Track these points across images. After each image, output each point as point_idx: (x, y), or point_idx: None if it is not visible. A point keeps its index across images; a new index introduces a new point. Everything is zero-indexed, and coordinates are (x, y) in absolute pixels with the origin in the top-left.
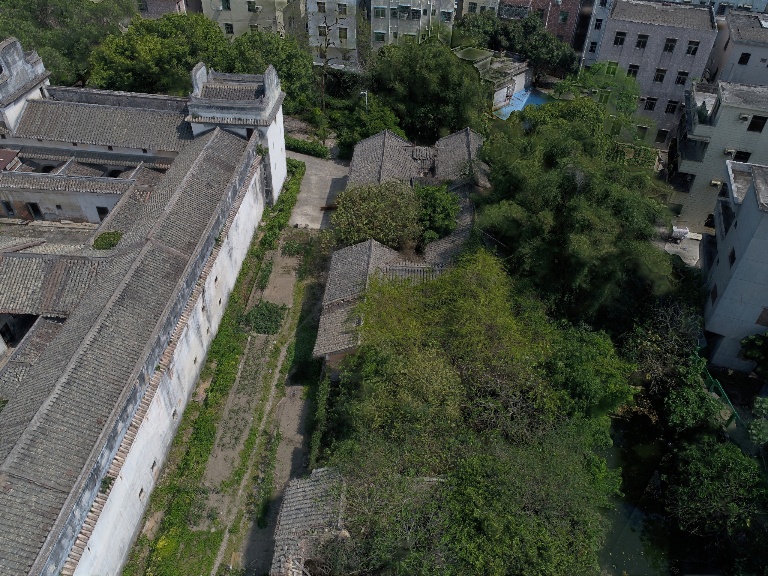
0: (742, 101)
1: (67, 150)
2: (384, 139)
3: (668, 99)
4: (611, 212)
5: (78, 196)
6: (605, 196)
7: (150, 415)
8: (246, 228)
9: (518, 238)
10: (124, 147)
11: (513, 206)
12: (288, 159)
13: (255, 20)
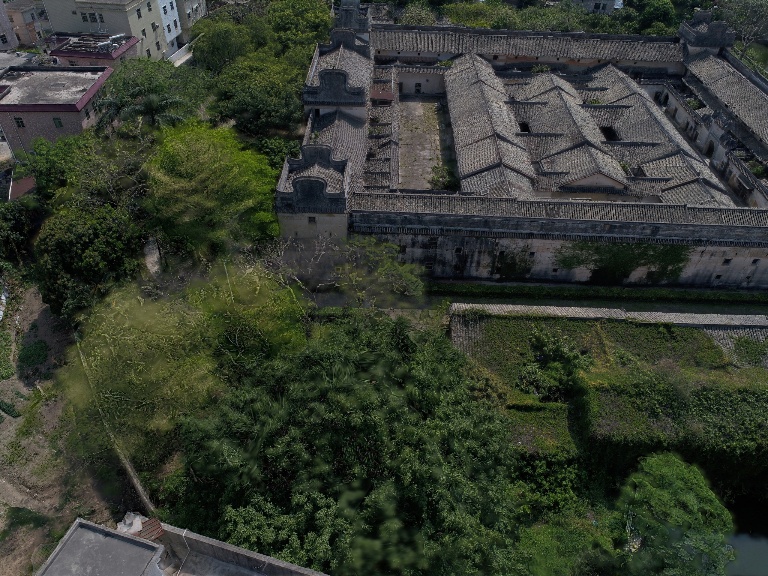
0: None
1: None
2: None
3: None
4: None
5: None
6: None
7: None
8: None
9: None
10: None
11: None
12: None
13: (157, 37)
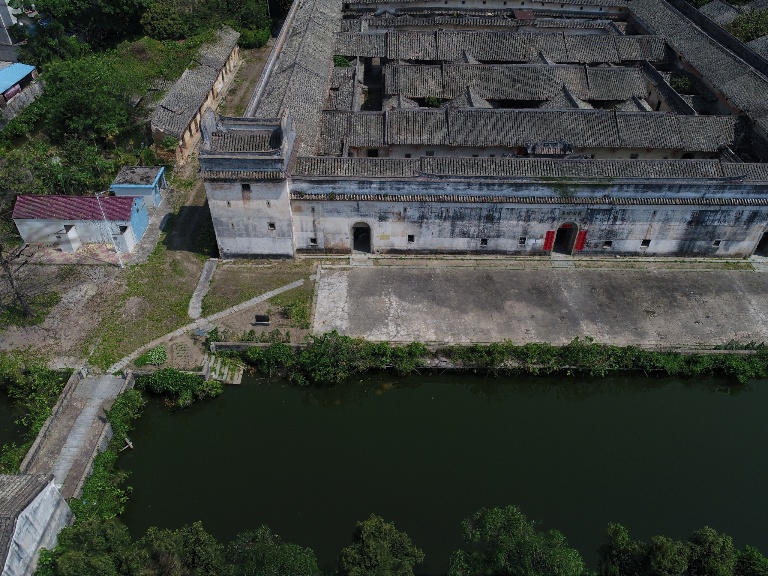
0: None
1: (556, 10)
2: (723, 2)
3: None
4: None
5: None
6: None
7: None
8: None
9: None
10: None
11: None
12: None
13: None
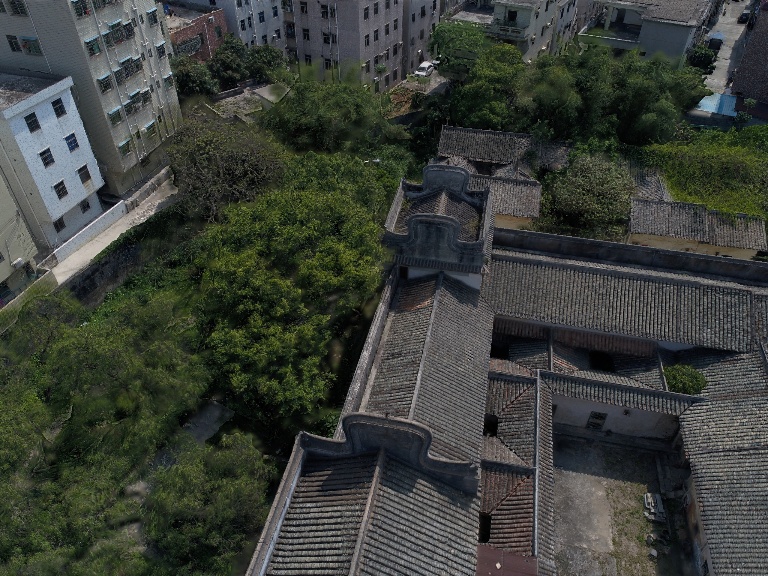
0: (530, 3)
1: None
2: None
3: (393, 45)
4: None
5: None
6: None
7: None
8: None
9: (656, 123)
10: None
11: (664, 101)
12: None
13: None
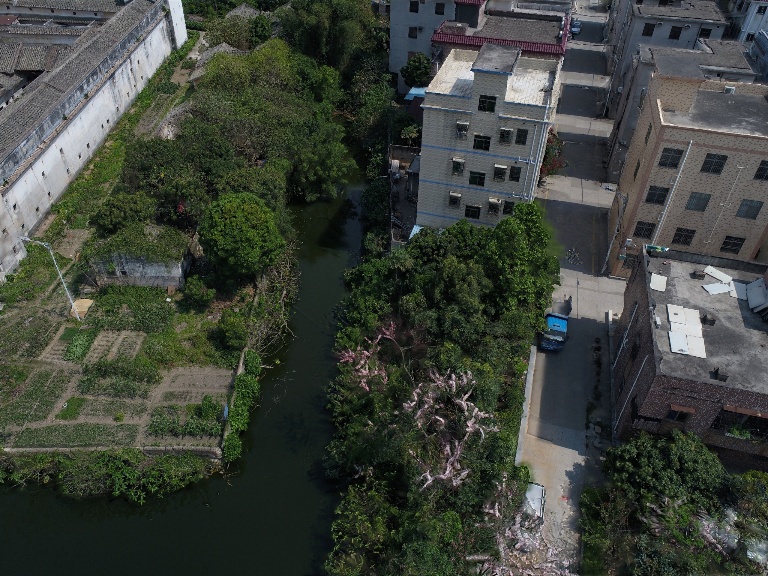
0: None
1: (48, 16)
2: (242, 7)
3: None
4: (332, 8)
5: (57, 40)
6: (330, 1)
7: (105, 93)
8: (158, 51)
9: None
10: (83, 12)
11: (287, 9)
12: (189, 31)
13: None
